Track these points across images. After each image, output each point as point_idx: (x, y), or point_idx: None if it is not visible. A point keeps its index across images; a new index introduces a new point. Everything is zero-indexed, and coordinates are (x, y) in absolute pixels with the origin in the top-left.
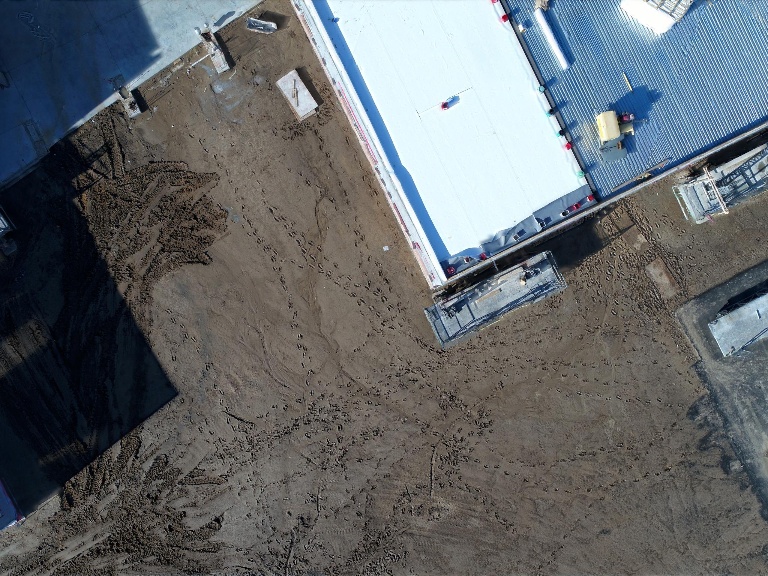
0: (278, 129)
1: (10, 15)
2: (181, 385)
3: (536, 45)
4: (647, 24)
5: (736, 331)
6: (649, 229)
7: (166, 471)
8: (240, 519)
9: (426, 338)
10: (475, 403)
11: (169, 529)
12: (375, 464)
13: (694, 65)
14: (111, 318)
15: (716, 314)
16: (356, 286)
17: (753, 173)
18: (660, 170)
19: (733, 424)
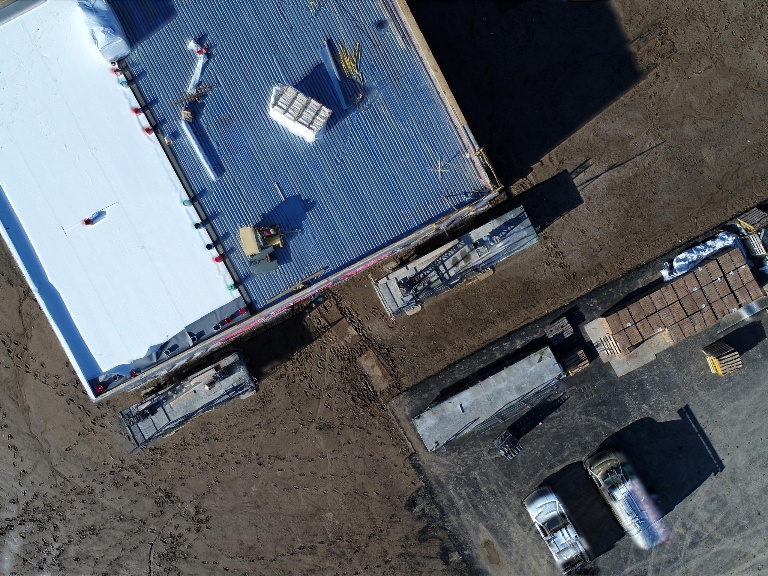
0: None
1: None
2: None
3: (185, 157)
4: (297, 133)
5: (440, 426)
6: (359, 321)
7: None
8: None
9: None
10: (191, 499)
11: None
12: (92, 563)
13: (348, 173)
14: None
15: (428, 406)
16: (64, 385)
17: (447, 268)
18: (316, 280)
19: (449, 516)
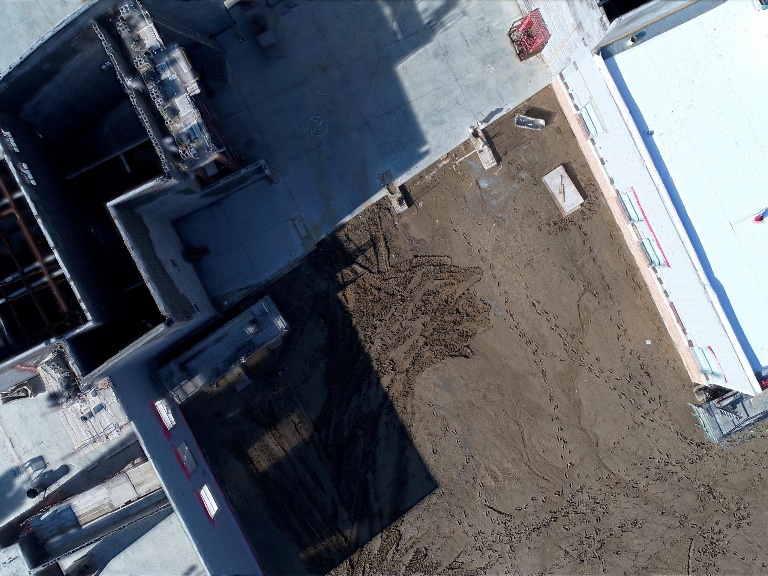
0: (543, 224)
1: (279, 112)
2: (441, 478)
3: None
4: None
5: None
6: None
7: (425, 564)
8: None
9: (686, 431)
10: (733, 495)
11: None
12: (633, 556)
13: None
14: (374, 411)
15: None
16: (617, 379)
17: None
18: None
19: None
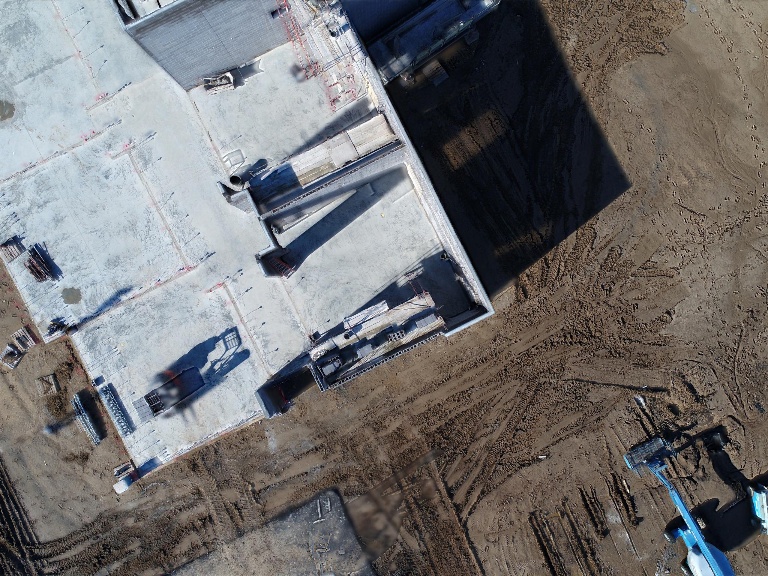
0: None
1: None
2: (635, 177)
3: None
4: None
5: None
6: None
7: (620, 263)
8: (691, 312)
9: None
10: None
11: (622, 321)
12: None
13: None
14: (570, 108)
15: None
16: None
17: None
18: None
19: None
